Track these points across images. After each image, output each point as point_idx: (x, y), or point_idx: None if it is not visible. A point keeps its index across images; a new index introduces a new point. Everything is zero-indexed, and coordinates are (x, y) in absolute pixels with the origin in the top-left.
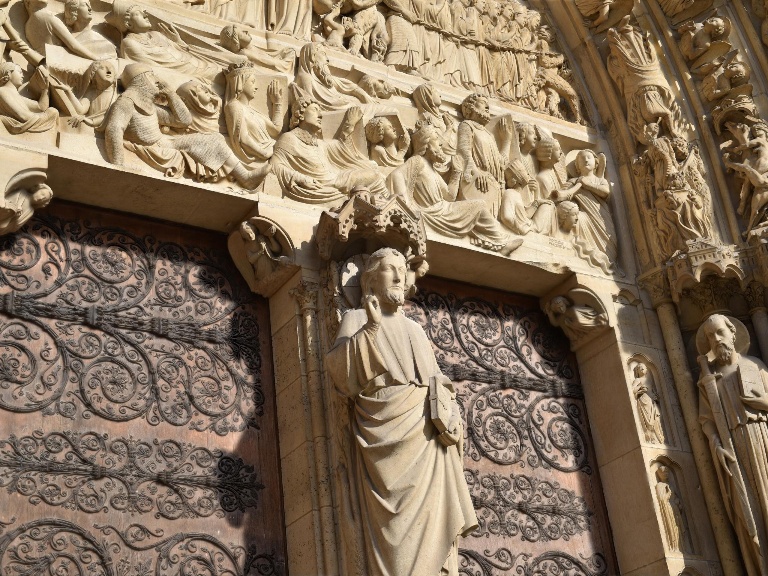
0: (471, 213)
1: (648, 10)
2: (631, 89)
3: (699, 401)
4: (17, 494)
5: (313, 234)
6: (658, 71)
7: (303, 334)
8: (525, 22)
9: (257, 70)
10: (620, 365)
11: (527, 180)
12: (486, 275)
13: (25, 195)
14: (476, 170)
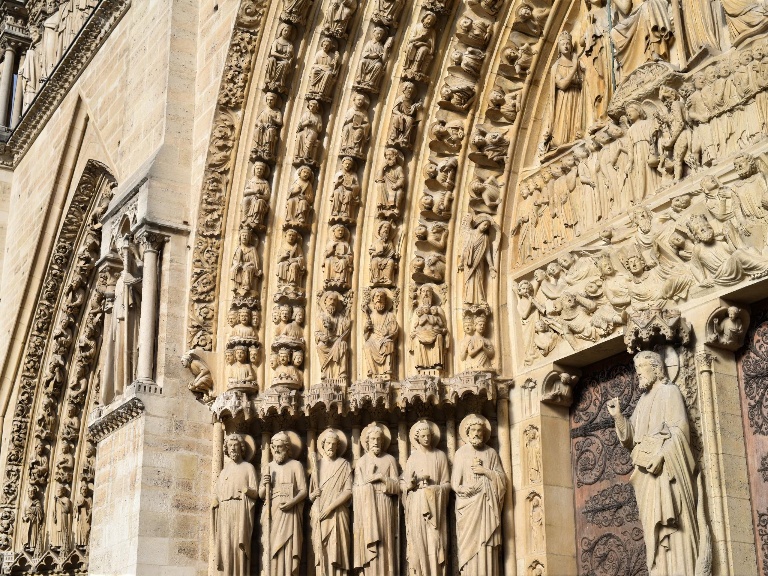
0: (734, 264)
1: None
2: None
3: None
4: None
5: None
6: None
7: None
8: None
9: None
10: None
11: None
12: None
13: (559, 383)
14: None
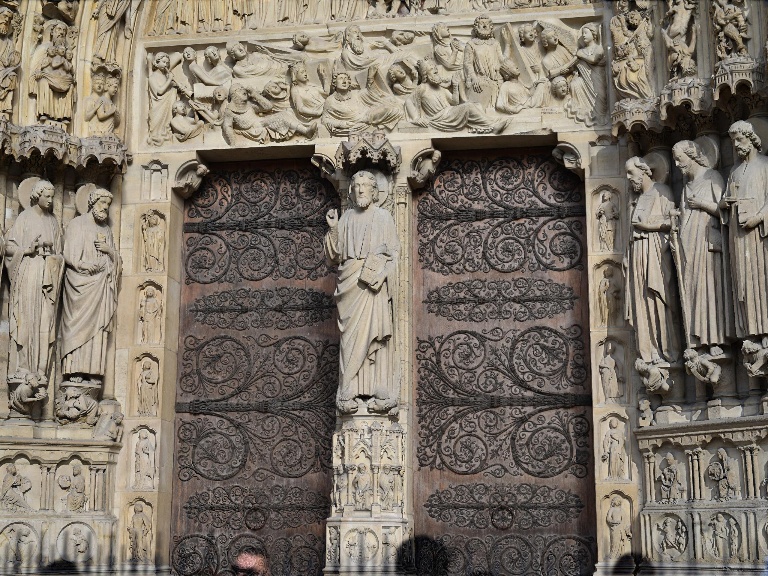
0: (462, 114)
1: None
2: None
3: None
4: (206, 325)
5: None
6: None
7: None
8: None
9: (314, 58)
10: None
11: (516, 73)
12: (501, 144)
13: (193, 173)
14: (474, 78)
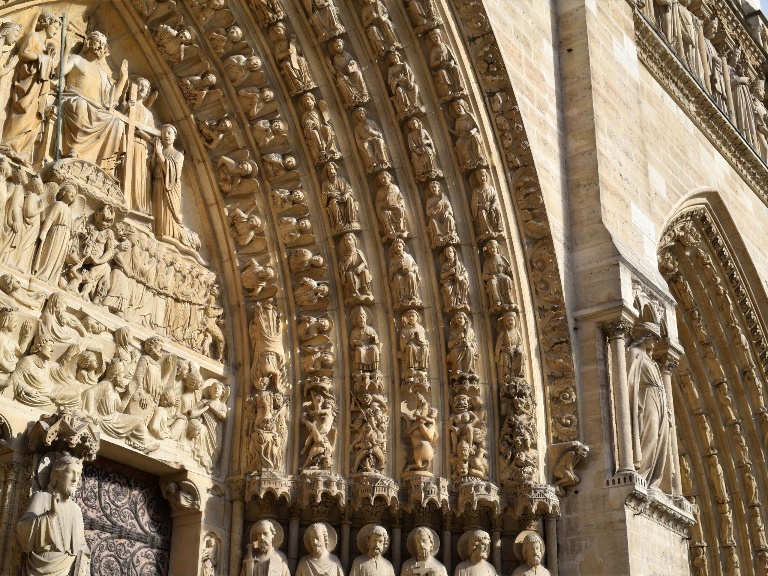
0: (131, 425)
1: (286, 296)
2: (259, 349)
3: (241, 572)
4: None
5: (27, 428)
6: (280, 342)
7: (3, 495)
8: (204, 281)
9: (19, 308)
10: (199, 538)
11: (174, 403)
12: (129, 460)
13: None
14: (143, 393)
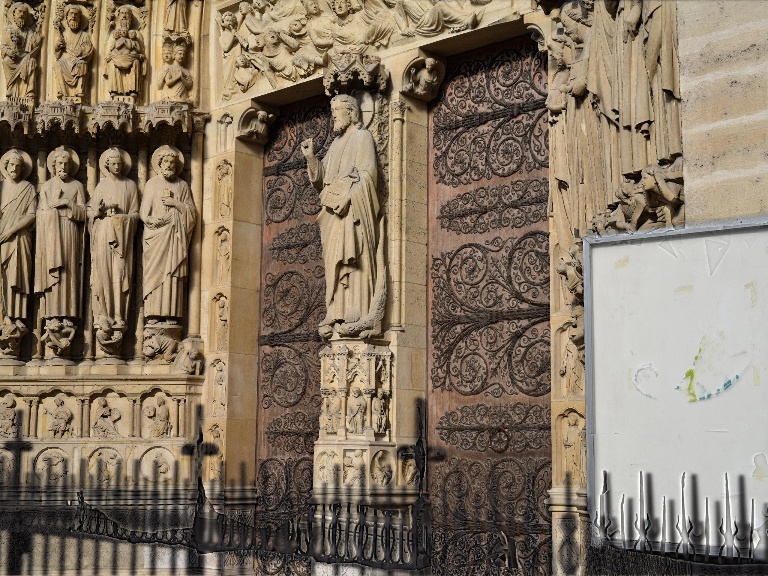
0: (436, 15)
1: None
2: None
3: None
4: (280, 261)
5: None
6: None
7: None
8: None
9: None
10: None
11: None
12: (491, 37)
13: (256, 120)
14: None
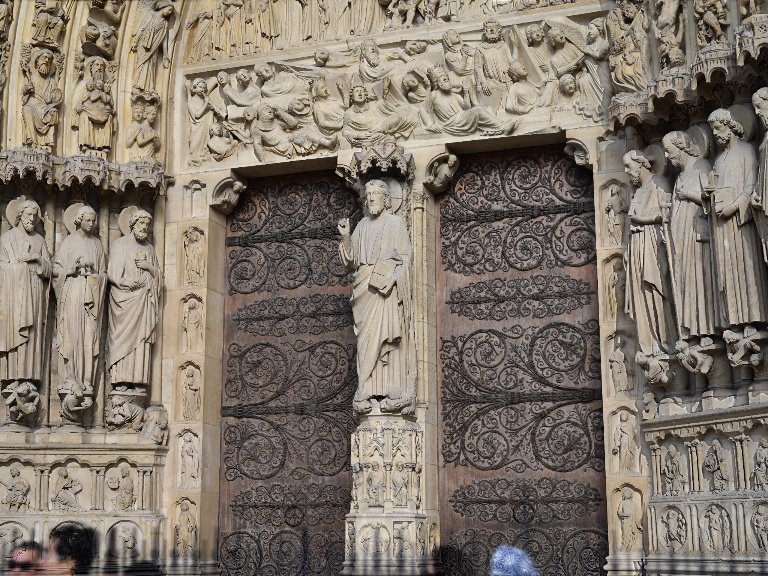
0: (472, 118)
1: None
2: None
3: None
4: (248, 333)
5: None
6: None
7: None
8: None
9: (334, 73)
10: None
11: (524, 74)
12: (515, 144)
13: (230, 190)
14: (484, 81)
